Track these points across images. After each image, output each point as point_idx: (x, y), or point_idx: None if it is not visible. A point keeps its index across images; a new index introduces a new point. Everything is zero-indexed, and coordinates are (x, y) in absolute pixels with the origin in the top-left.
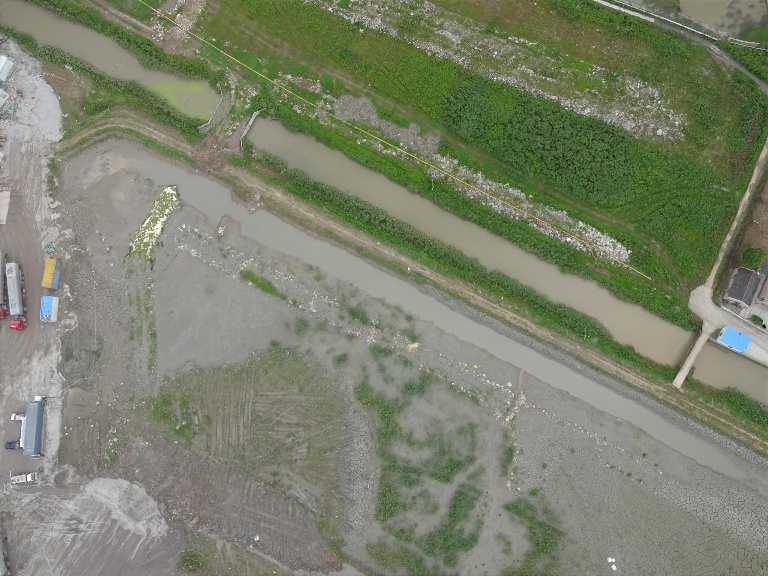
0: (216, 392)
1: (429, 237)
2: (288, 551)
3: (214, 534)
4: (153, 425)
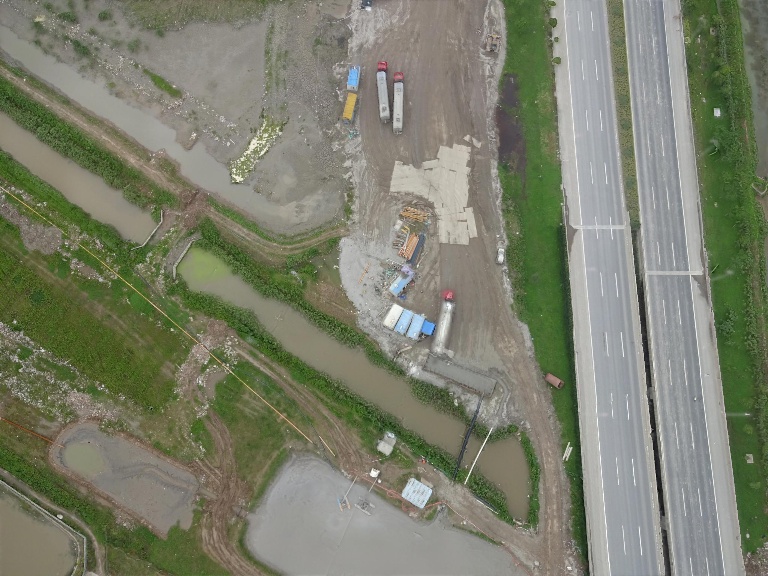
0: (216, 1)
1: (1, 109)
2: None
3: None
4: None
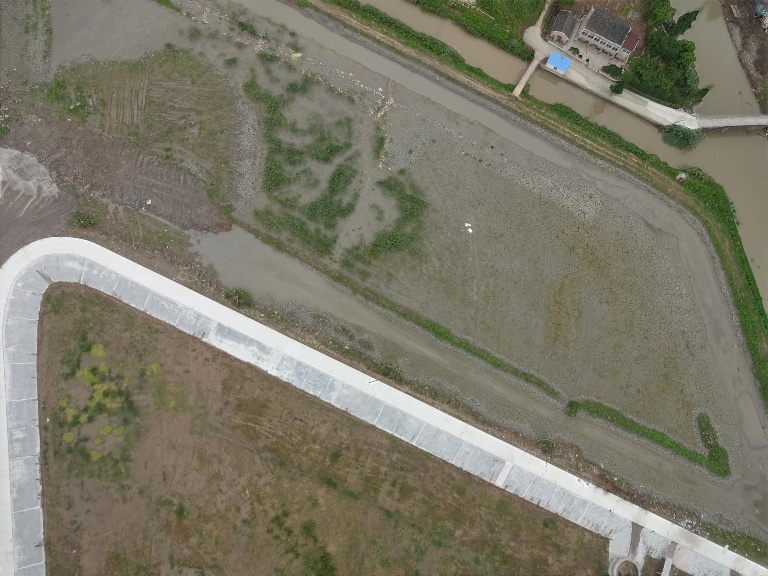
0: (111, 80)
1: None
2: (179, 213)
3: (106, 199)
4: (46, 105)
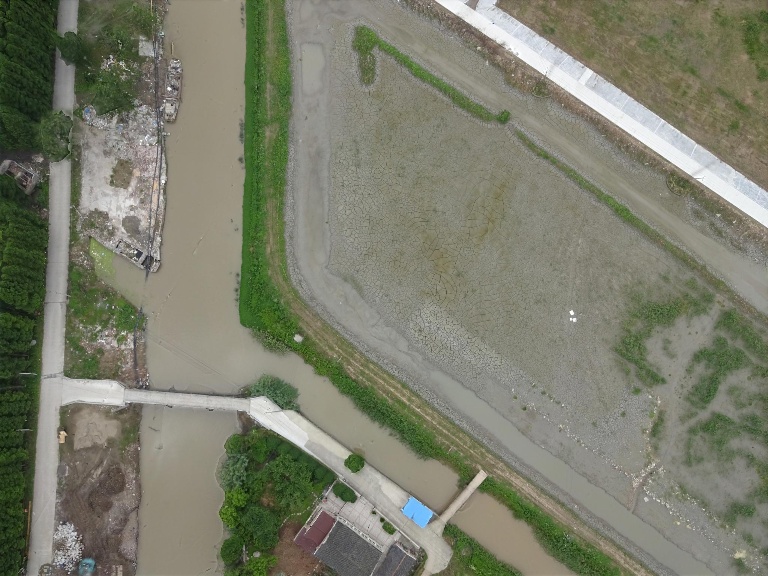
0: None
1: None
2: None
3: None
4: None
